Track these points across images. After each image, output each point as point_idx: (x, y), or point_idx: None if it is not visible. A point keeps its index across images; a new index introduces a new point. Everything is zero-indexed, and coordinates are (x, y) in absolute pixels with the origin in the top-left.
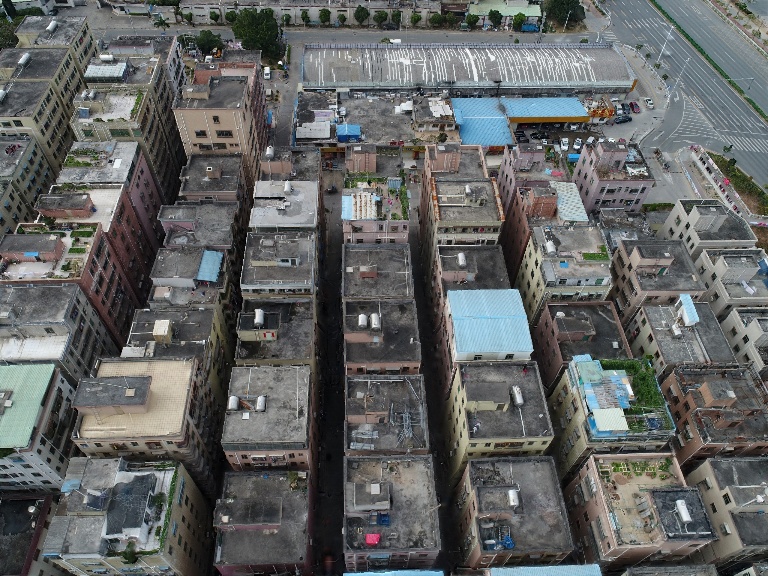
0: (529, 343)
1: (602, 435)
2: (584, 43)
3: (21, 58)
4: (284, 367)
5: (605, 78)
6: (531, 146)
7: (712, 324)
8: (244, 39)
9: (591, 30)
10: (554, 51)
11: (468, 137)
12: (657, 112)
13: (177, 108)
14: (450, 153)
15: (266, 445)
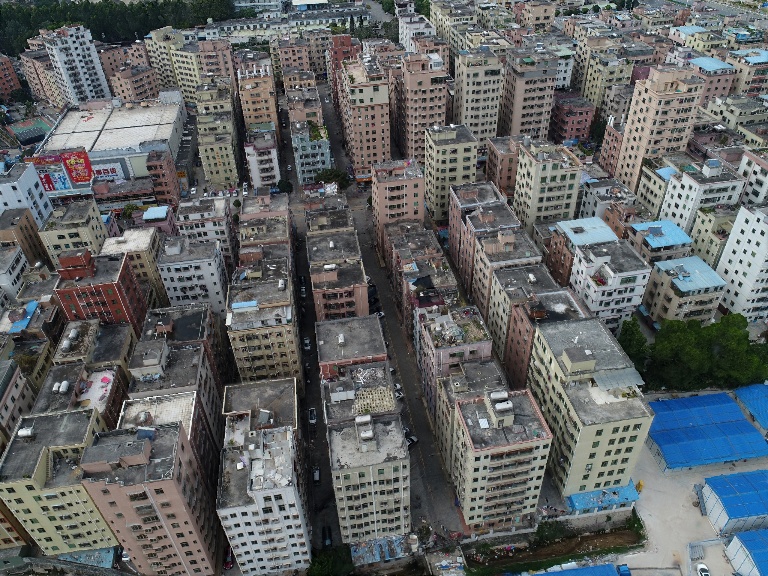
0: None
1: (743, 38)
2: (647, 8)
3: (452, 5)
4: (633, 42)
5: None
6: (669, 4)
7: None
8: None
9: None
10: None
11: None
12: None
13: (533, 6)
14: (641, 8)
15: (642, 52)
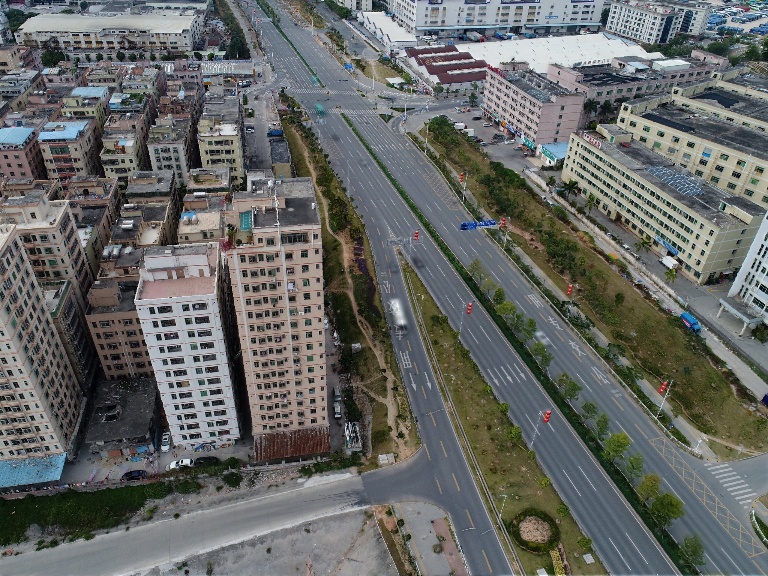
0: (101, 94)
1: (113, 107)
2: (237, 60)
3: None
4: None
5: None
6: (143, 60)
7: None
8: (44, 61)
9: (254, 61)
10: None
11: None
12: (266, 84)
13: None
14: (104, 62)
15: None
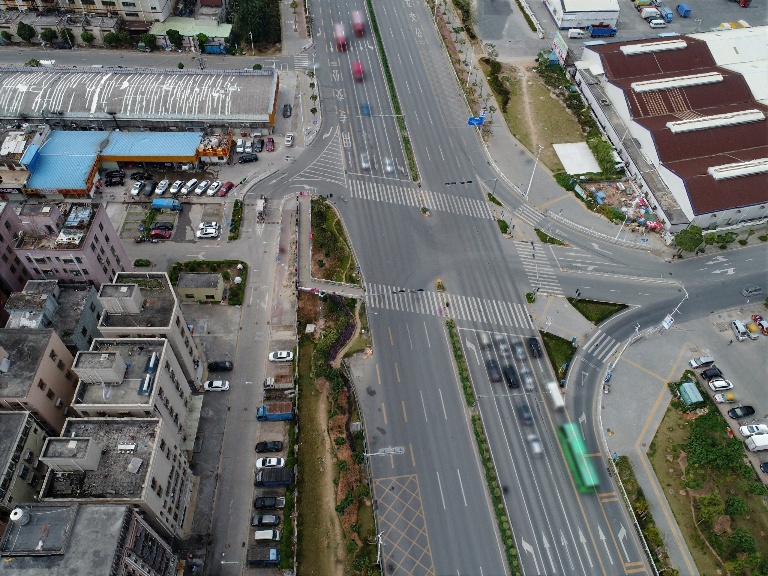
0: None
1: None
2: (243, 70)
3: None
4: None
5: (241, 111)
6: None
7: (5, 442)
8: None
9: (285, 53)
10: (205, 78)
11: (41, 178)
12: (294, 150)
13: None
14: None
15: None
